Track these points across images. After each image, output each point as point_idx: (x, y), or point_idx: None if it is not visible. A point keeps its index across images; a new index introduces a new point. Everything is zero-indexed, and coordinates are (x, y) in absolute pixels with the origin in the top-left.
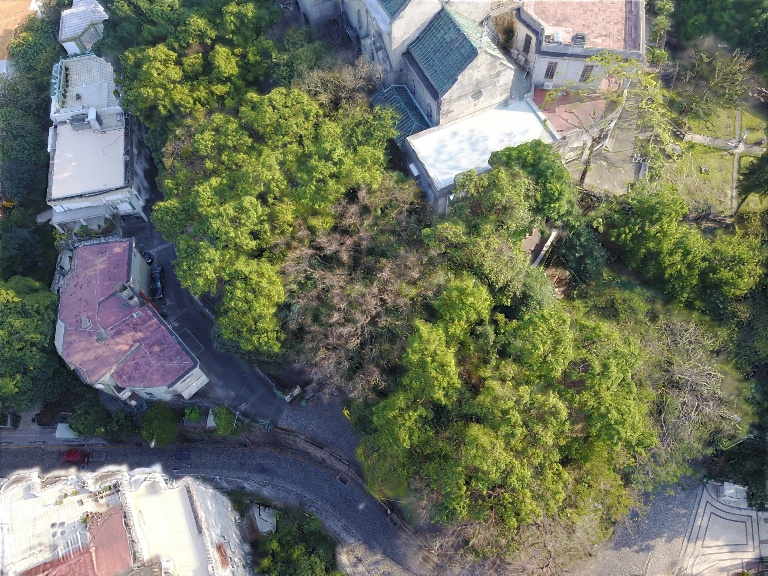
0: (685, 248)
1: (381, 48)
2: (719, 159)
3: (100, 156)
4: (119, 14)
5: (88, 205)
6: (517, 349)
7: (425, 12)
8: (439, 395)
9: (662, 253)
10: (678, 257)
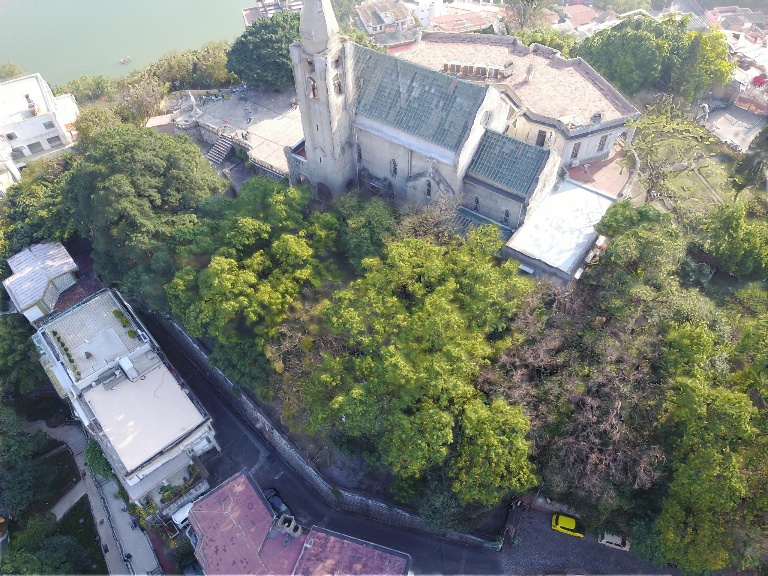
0: (766, 238)
1: (441, 181)
2: (687, 177)
3: (156, 402)
4: (142, 247)
5: (165, 461)
6: (766, 362)
7: (475, 137)
8: (749, 432)
9: (756, 249)
10: (767, 247)
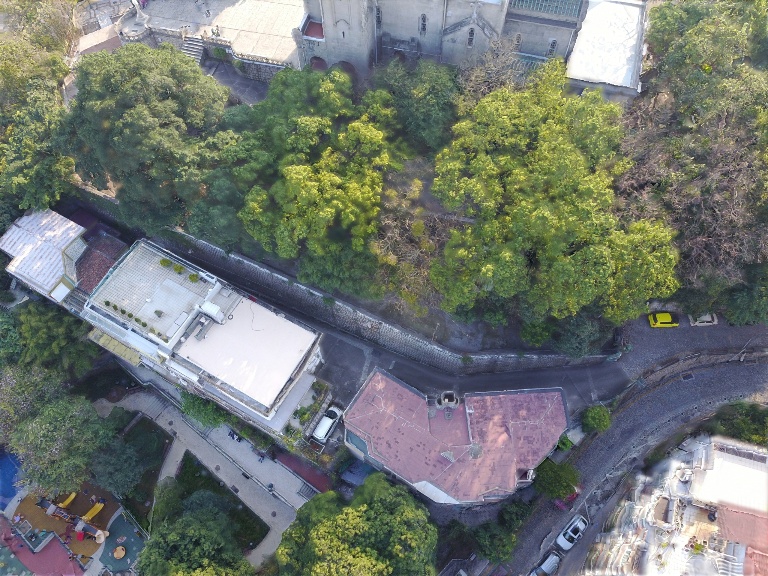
0: None
1: (484, 25)
2: None
3: (259, 335)
4: (196, 180)
5: None
6: None
7: None
8: None
9: None
10: None
